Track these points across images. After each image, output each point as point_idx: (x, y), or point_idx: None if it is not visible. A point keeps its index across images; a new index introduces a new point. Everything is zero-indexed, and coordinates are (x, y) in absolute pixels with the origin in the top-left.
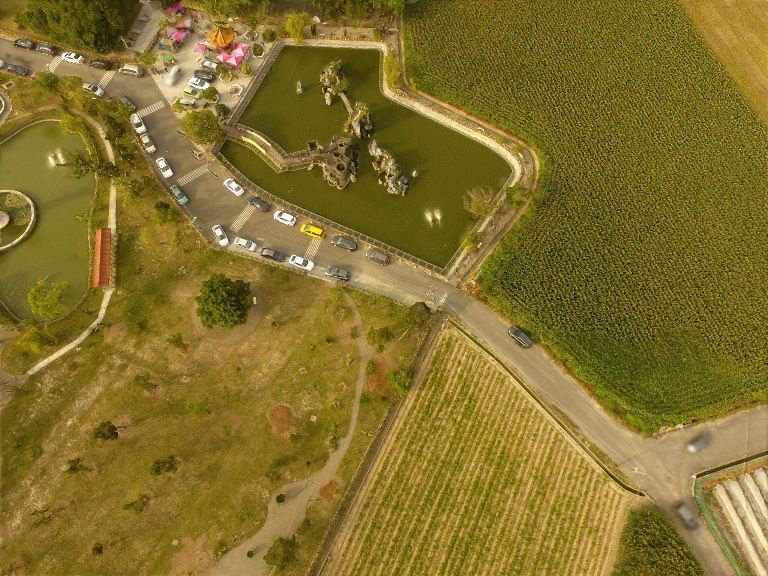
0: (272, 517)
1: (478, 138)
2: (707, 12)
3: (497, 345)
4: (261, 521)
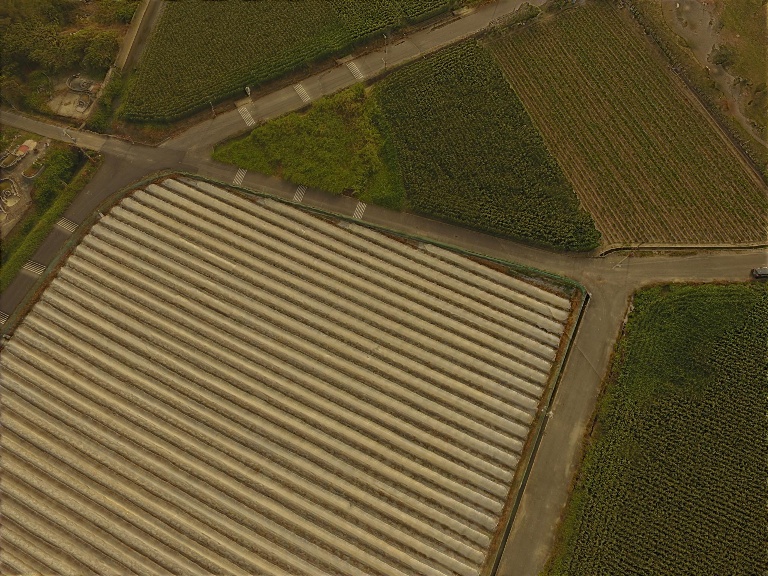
0: (726, 75)
1: None
2: None
3: (764, 256)
4: (727, 70)
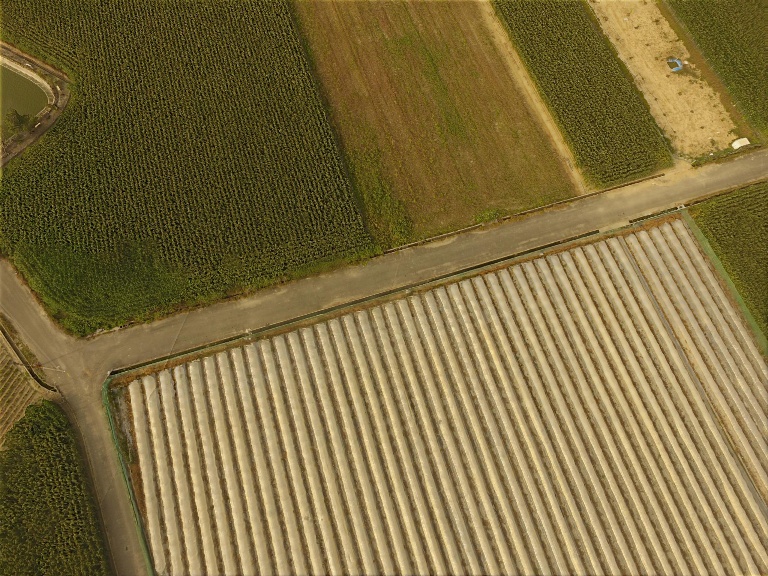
0: None
1: (28, 74)
2: None
3: None
4: None
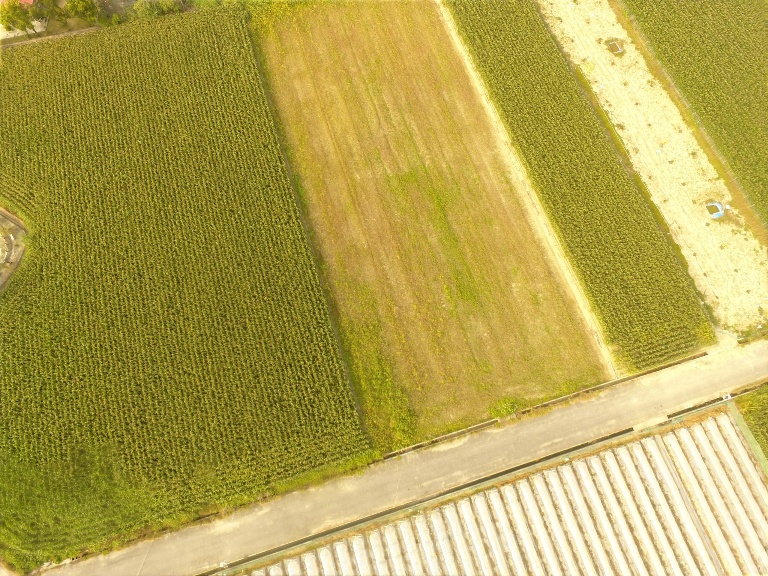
0: None
1: None
2: (292, 62)
3: None
4: None
